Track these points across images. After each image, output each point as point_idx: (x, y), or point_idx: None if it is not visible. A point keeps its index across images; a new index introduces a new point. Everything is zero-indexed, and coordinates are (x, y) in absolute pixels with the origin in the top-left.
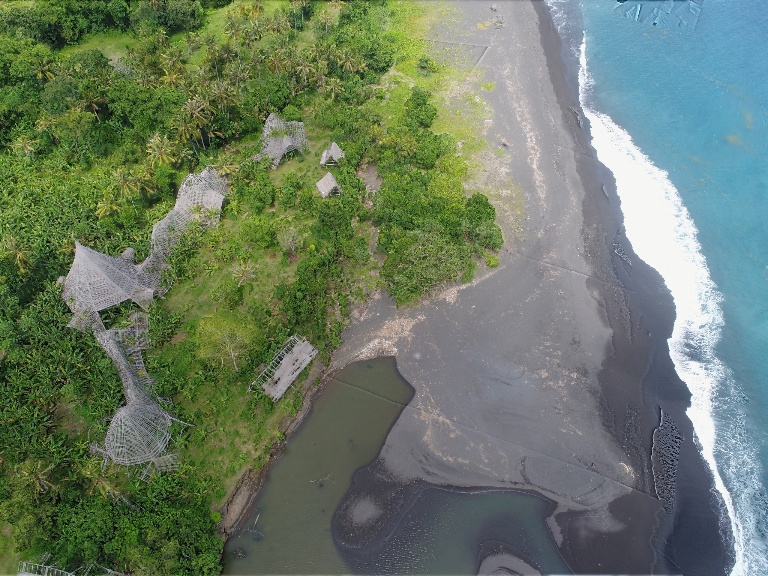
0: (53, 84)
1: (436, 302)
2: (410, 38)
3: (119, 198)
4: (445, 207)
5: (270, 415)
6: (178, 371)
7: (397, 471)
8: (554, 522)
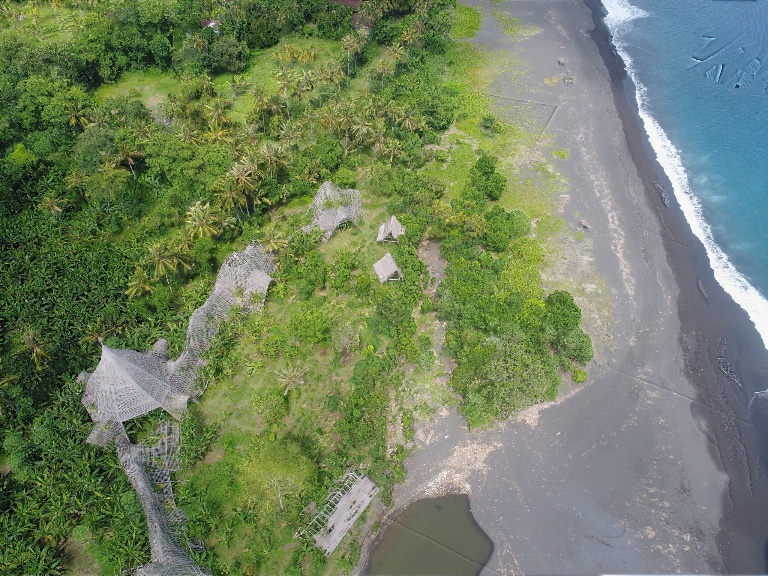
0: (87, 136)
1: (514, 424)
2: (471, 92)
3: (152, 271)
4: (524, 306)
5: (321, 572)
6: (212, 502)
7: None
8: None
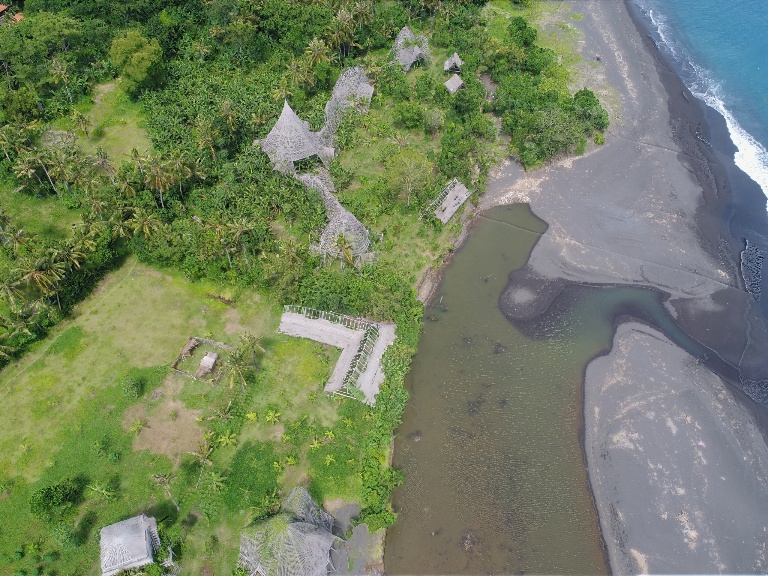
0: (218, 1)
1: (556, 168)
2: None
3: None
4: (558, 98)
5: (439, 235)
6: None
7: (543, 273)
8: (670, 305)
